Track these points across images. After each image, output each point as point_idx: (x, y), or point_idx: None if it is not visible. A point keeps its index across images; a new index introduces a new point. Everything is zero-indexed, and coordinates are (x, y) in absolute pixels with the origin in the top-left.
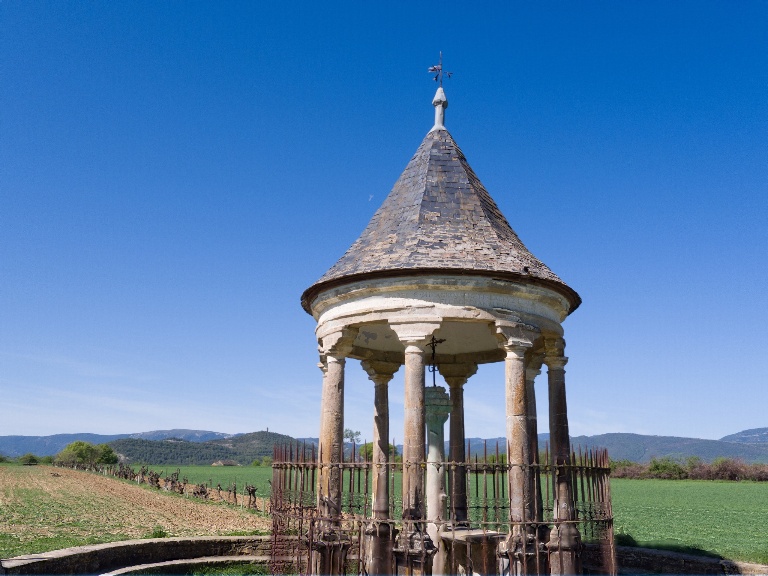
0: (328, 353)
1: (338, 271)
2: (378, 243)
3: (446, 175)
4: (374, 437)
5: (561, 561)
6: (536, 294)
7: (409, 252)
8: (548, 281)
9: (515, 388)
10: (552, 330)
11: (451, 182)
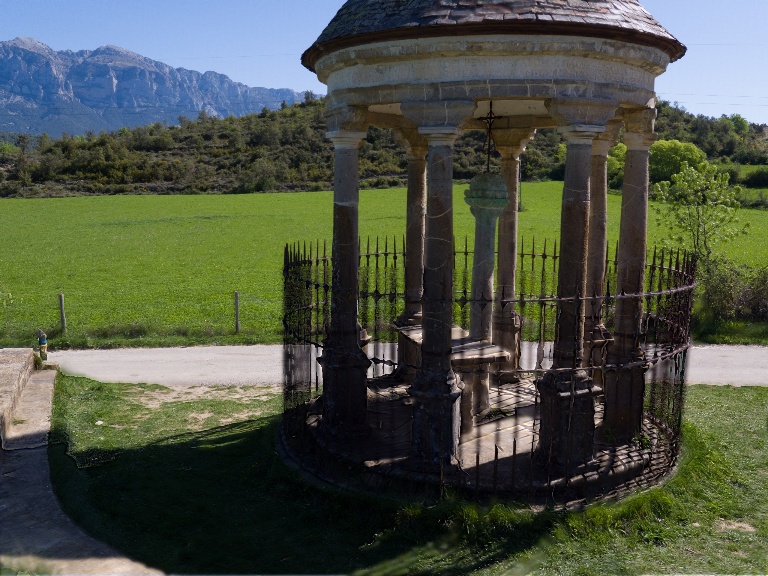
0: None
1: None
2: None
3: None
4: None
5: None
6: None
7: None
8: None
9: None
10: None
11: None
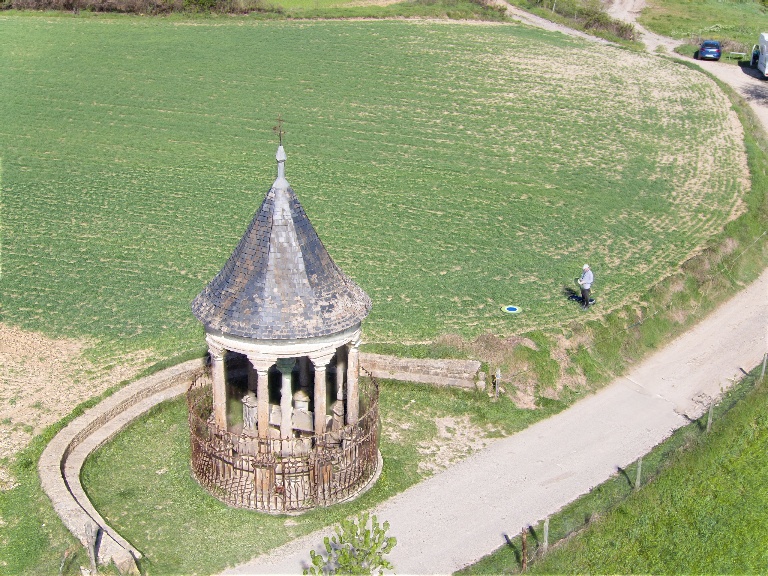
0: (263, 371)
1: (276, 331)
2: (292, 306)
3: (306, 235)
4: None
5: (345, 419)
6: None
7: (321, 319)
8: None
9: (356, 366)
10: None
11: (311, 241)
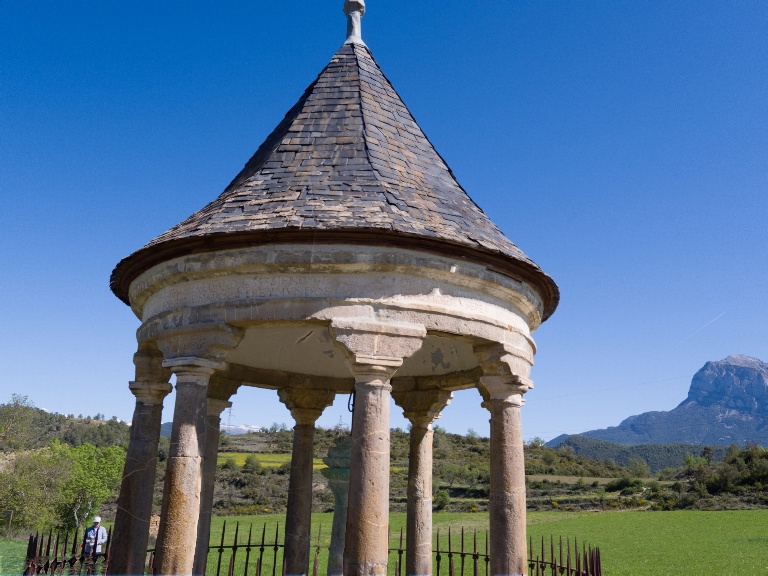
0: None
1: None
2: None
3: None
4: (195, 510)
5: None
6: None
7: None
8: None
9: None
10: None
11: None
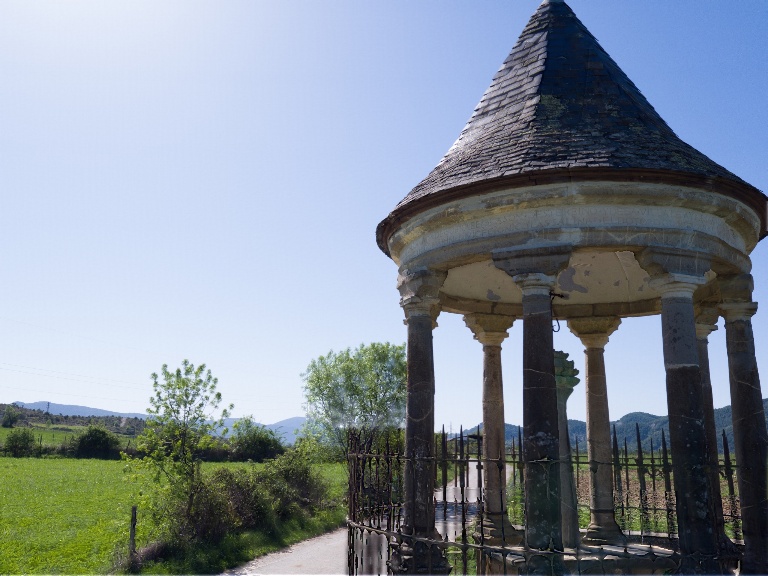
0: None
1: None
2: None
3: None
4: None
5: None
6: (413, 229)
7: None
8: (410, 207)
9: None
10: (454, 258)
11: None
